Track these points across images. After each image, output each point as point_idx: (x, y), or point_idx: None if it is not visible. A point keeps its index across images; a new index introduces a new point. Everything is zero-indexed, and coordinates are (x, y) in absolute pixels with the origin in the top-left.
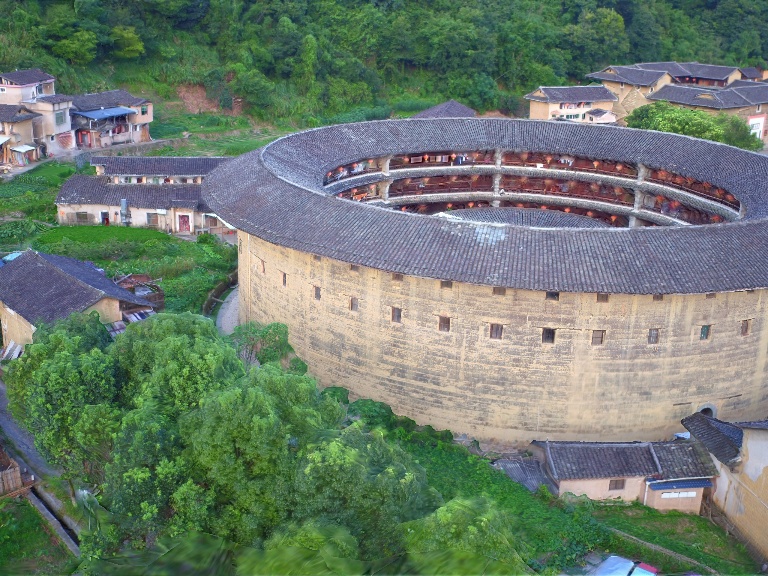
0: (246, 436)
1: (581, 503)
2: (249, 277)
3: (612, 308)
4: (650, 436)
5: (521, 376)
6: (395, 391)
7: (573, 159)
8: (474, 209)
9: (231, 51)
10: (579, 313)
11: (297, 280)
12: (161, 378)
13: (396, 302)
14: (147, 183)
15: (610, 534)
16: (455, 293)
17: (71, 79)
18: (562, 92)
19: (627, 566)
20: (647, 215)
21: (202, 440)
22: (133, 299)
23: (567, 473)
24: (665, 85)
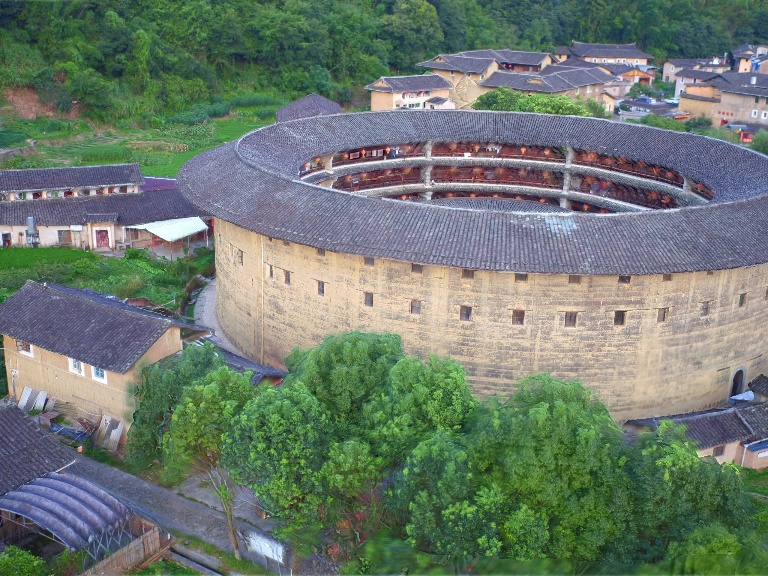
0: (567, 452)
1: None
2: (262, 290)
3: (675, 286)
4: (699, 403)
5: (594, 360)
6: None
7: (500, 147)
8: None
9: (55, 49)
10: (647, 293)
11: (341, 288)
12: (412, 404)
13: (466, 300)
14: (48, 198)
15: (748, 498)
16: (531, 285)
17: None
18: (403, 82)
19: None
20: (577, 196)
21: (528, 462)
22: None
23: None
24: (494, 72)
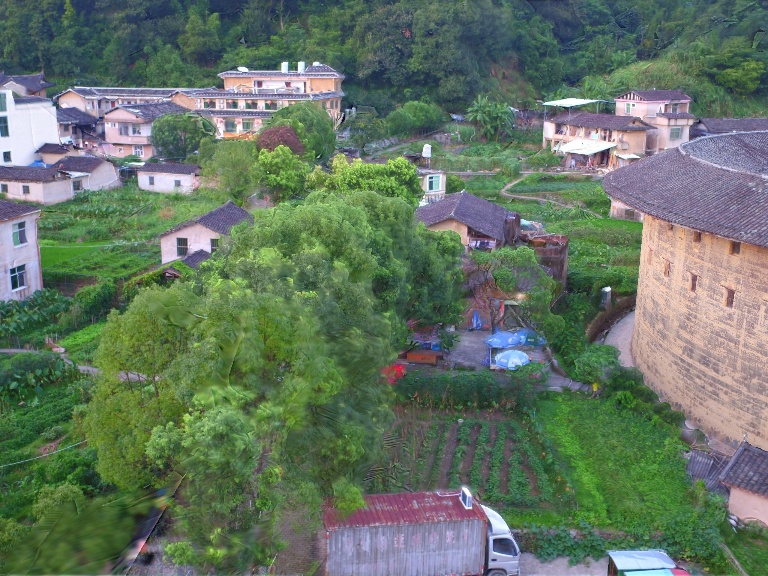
0: None
1: (714, 507)
2: None
3: None
4: None
5: None
6: (684, 373)
7: None
8: None
9: None
10: None
11: None
12: None
13: (694, 267)
14: None
15: (718, 550)
16: (741, 260)
17: (725, 106)
18: None
19: (660, 563)
20: None
21: None
22: (485, 230)
23: (740, 480)
24: None
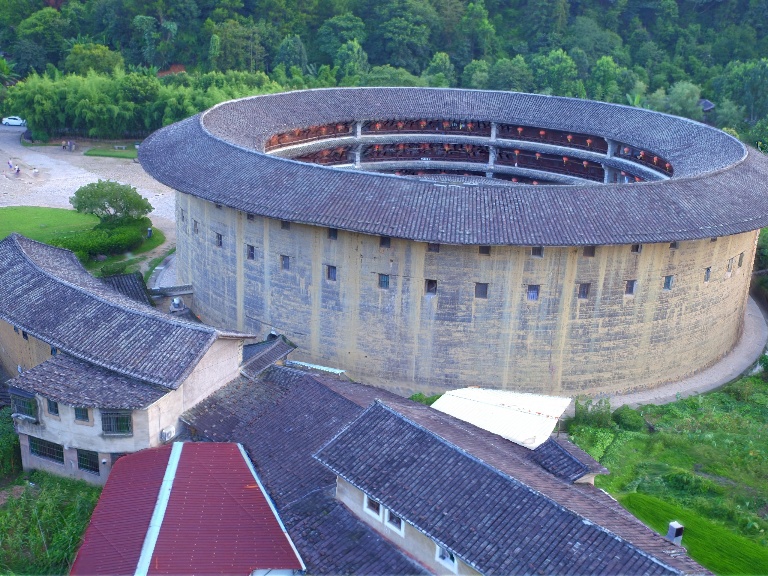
0: None
1: None
2: None
3: None
4: None
5: None
6: None
7: None
8: None
9: None
10: None
11: None
12: None
13: None
14: None
15: None
16: None
17: None
18: None
19: None
20: None
21: None
22: None
23: None
24: None
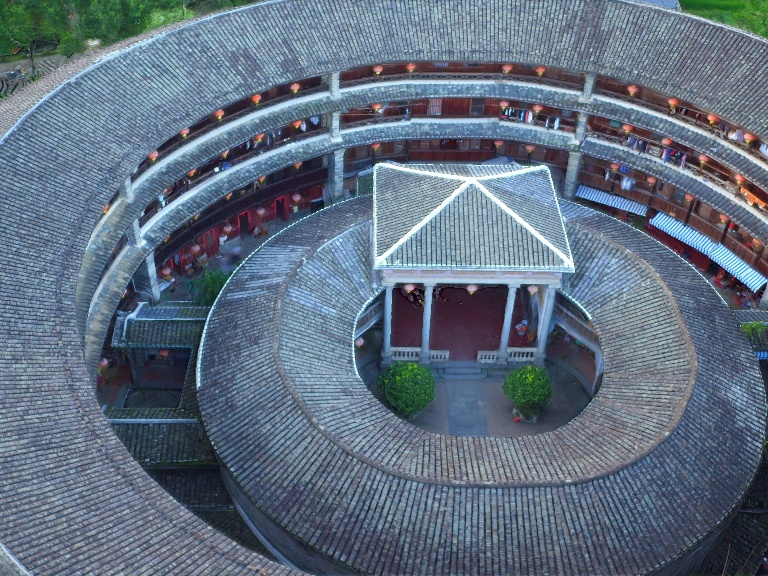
0: None
1: None
2: None
3: None
4: None
5: None
6: None
7: None
8: (680, 318)
9: None
10: None
11: None
12: None
13: None
14: None
15: None
16: None
17: None
18: None
19: None
20: None
21: None
22: None
23: None
24: None
